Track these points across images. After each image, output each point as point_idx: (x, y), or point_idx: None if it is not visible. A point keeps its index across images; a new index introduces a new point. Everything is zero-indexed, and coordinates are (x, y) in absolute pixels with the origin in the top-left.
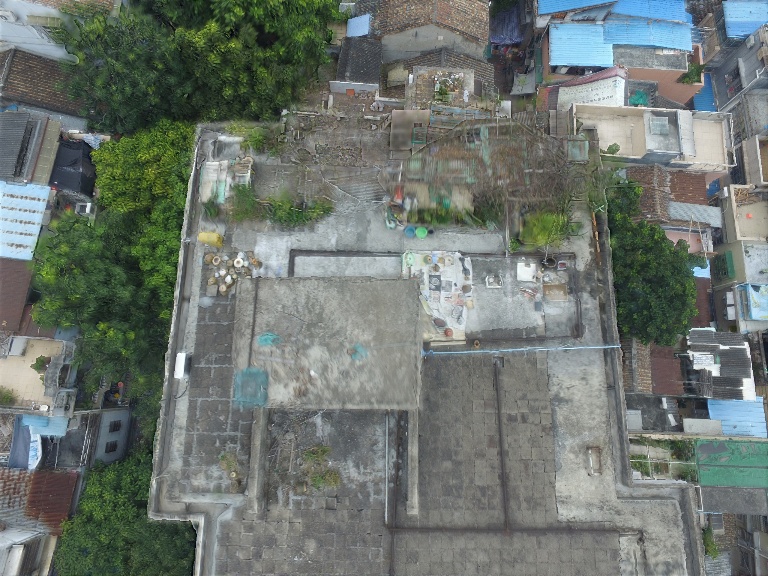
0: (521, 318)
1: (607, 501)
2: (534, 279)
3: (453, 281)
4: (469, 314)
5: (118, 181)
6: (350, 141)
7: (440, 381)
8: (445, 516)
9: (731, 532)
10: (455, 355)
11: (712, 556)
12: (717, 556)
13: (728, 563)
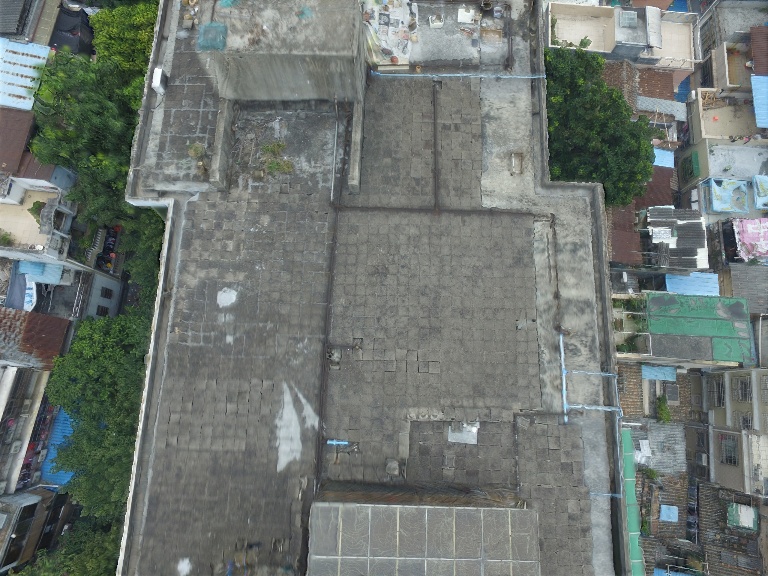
0: (459, 51)
1: (526, 195)
2: (472, 22)
3: (400, 20)
4: (413, 47)
5: (114, 41)
6: None
7: (385, 97)
8: (383, 199)
9: (686, 406)
10: (399, 77)
11: (665, 419)
12: (672, 428)
13: (683, 437)
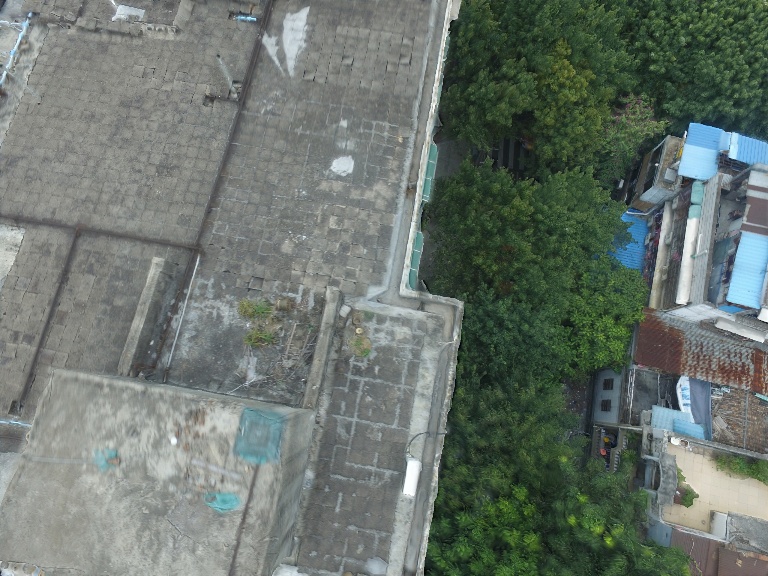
0: None
1: None
2: None
3: None
4: None
5: None
6: None
7: None
8: (138, 252)
9: None
10: None
11: None
12: None
13: None
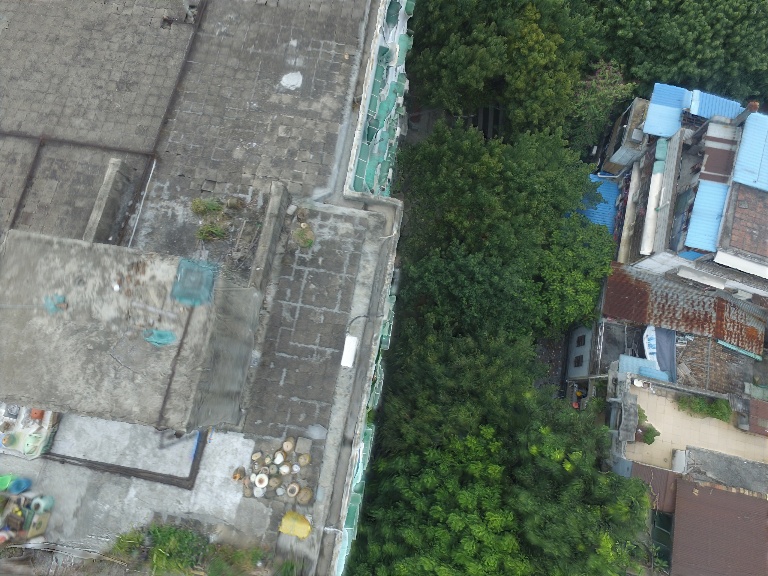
0: None
1: None
2: None
3: None
4: None
5: None
6: None
7: None
8: (98, 159)
9: None
10: None
11: None
12: None
13: None
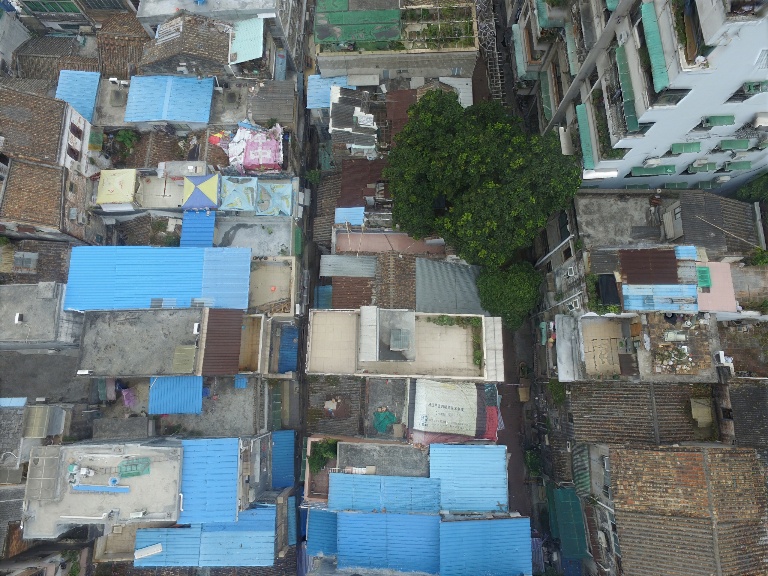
0: None
1: None
2: None
3: None
4: None
5: None
6: (762, 292)
7: None
8: None
9: None
10: None
11: None
12: None
13: None
